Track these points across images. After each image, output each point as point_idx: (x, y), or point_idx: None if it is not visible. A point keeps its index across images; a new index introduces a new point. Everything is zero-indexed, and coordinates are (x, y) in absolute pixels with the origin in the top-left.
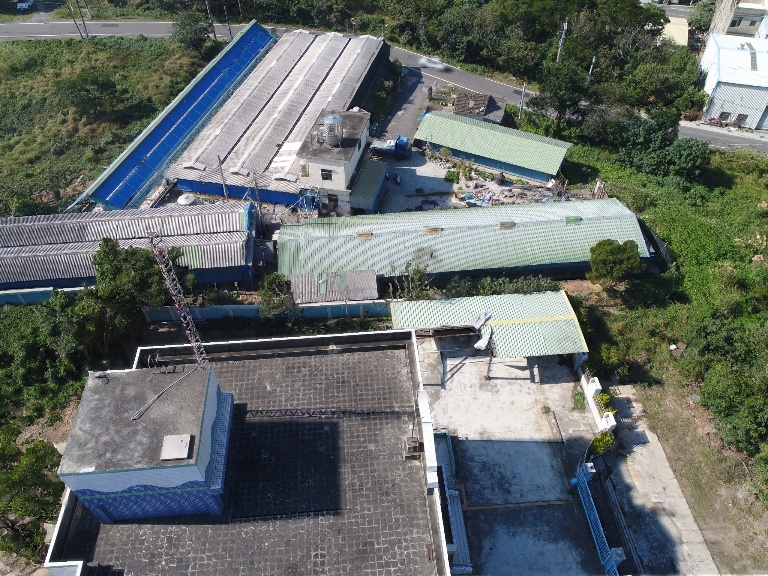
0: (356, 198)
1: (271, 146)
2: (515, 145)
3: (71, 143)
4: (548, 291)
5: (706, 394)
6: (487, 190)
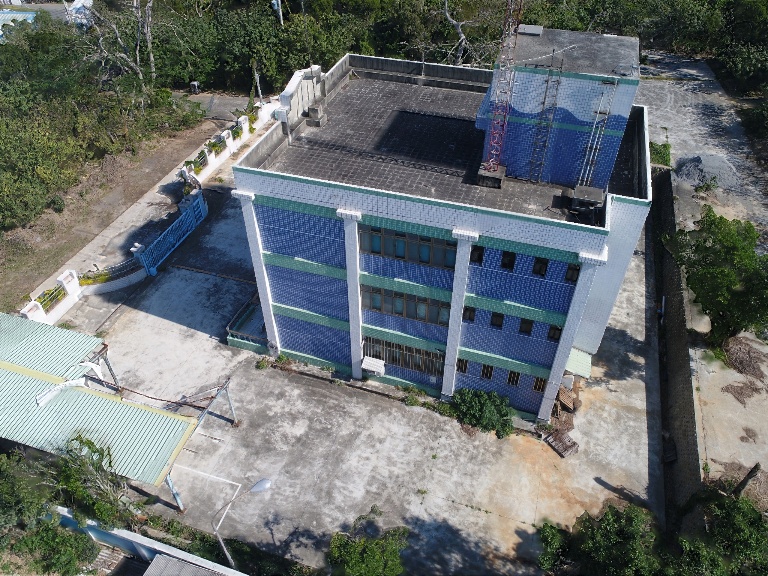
0: None
1: None
2: None
3: None
4: None
5: None
6: None
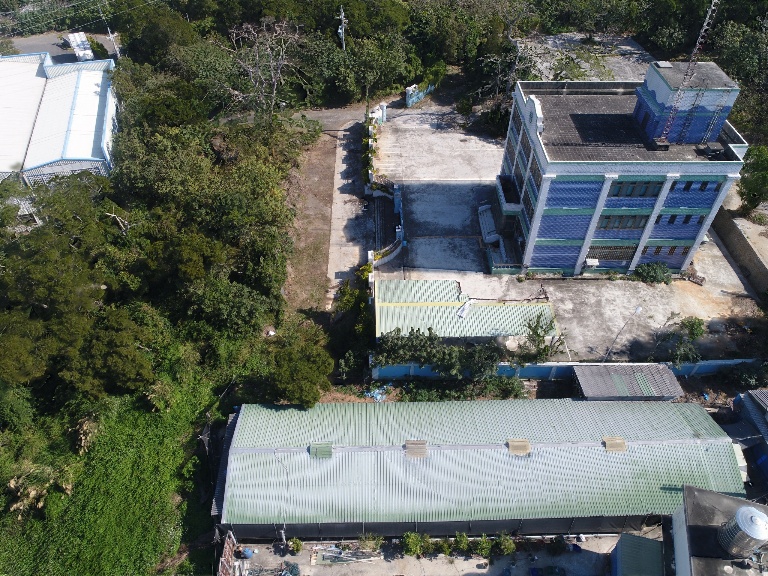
0: None
1: None
2: None
3: None
4: None
5: None
6: None
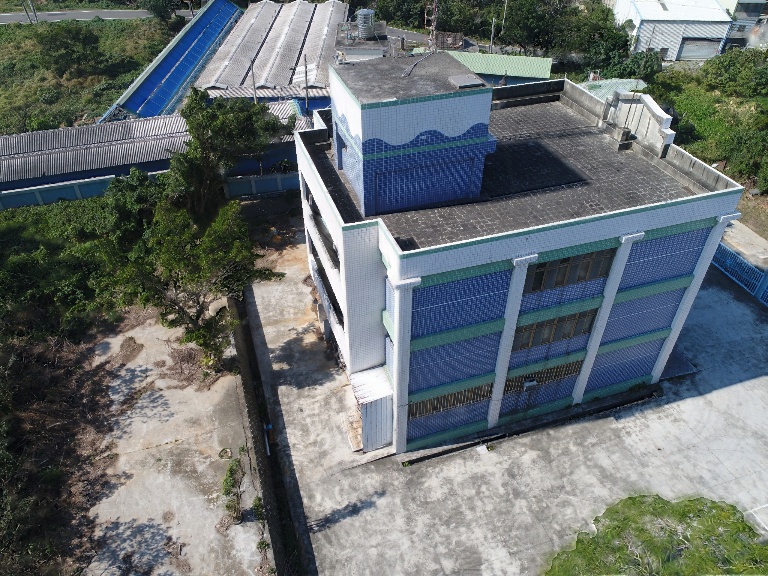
0: None
1: (285, 69)
2: (505, 61)
3: (60, 93)
4: None
5: (767, 176)
6: None
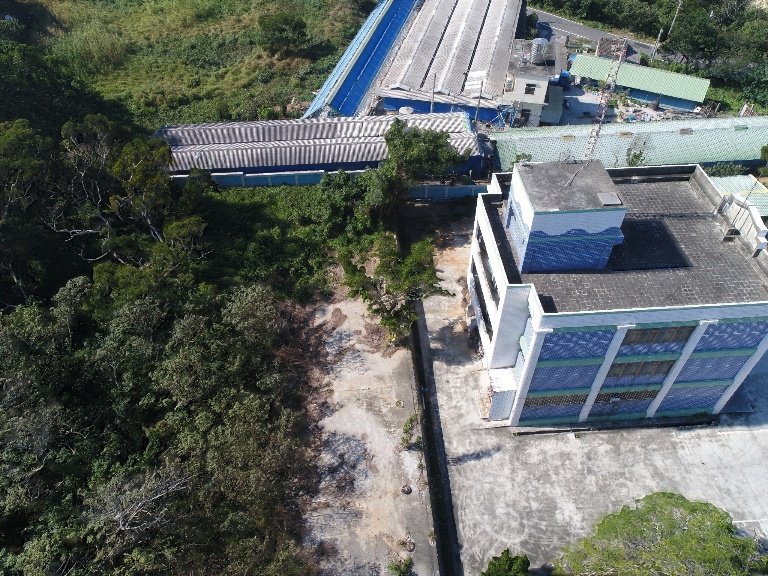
0: (547, 112)
1: (459, 74)
2: (663, 79)
3: (273, 73)
4: (739, 175)
5: None
6: (645, 114)
